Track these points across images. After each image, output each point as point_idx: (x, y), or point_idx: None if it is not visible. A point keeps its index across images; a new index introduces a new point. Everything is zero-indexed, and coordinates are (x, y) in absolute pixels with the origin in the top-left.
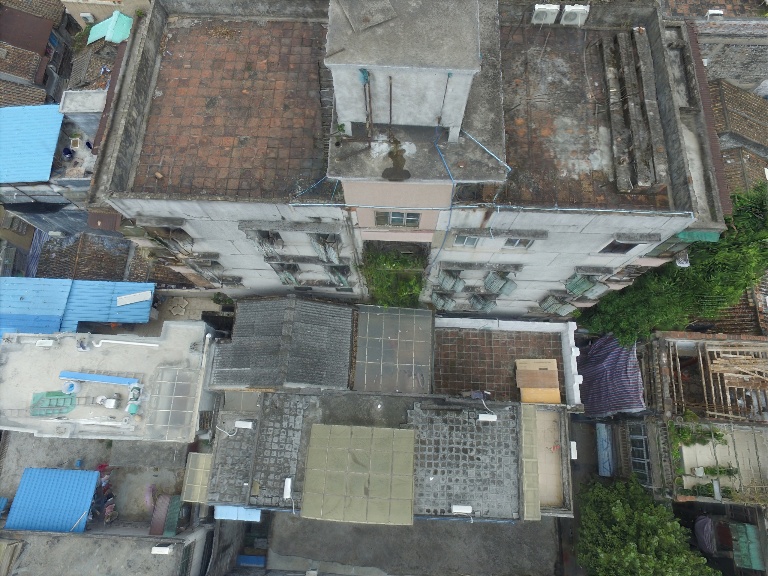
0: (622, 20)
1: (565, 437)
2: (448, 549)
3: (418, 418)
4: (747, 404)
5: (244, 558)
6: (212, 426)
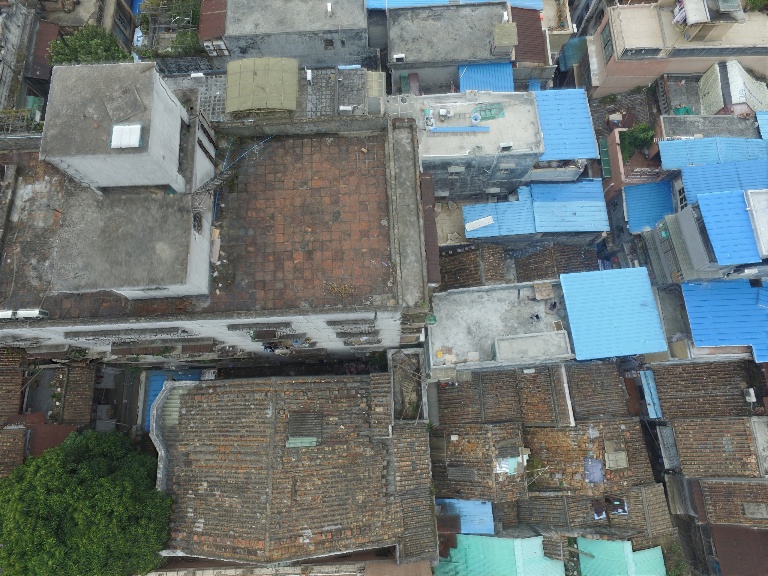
0: None
1: None
2: None
3: None
4: None
5: None
6: None
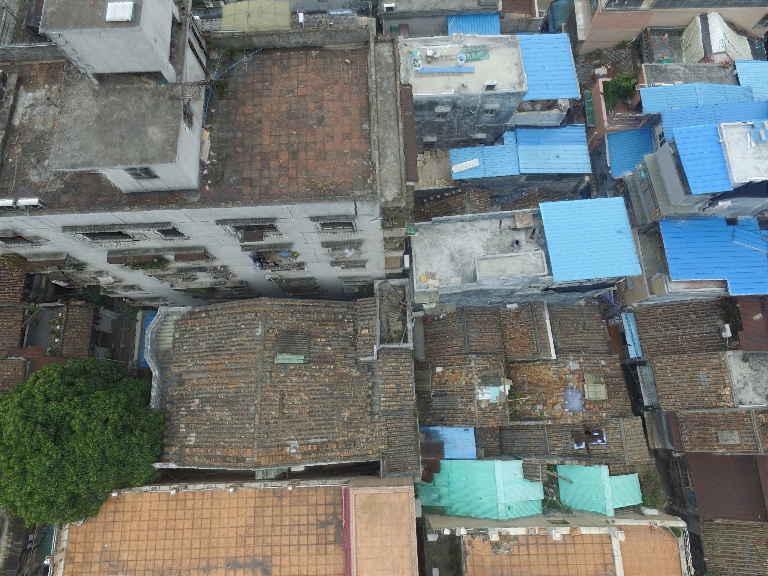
0: None
1: None
2: None
3: None
4: None
5: None
6: None
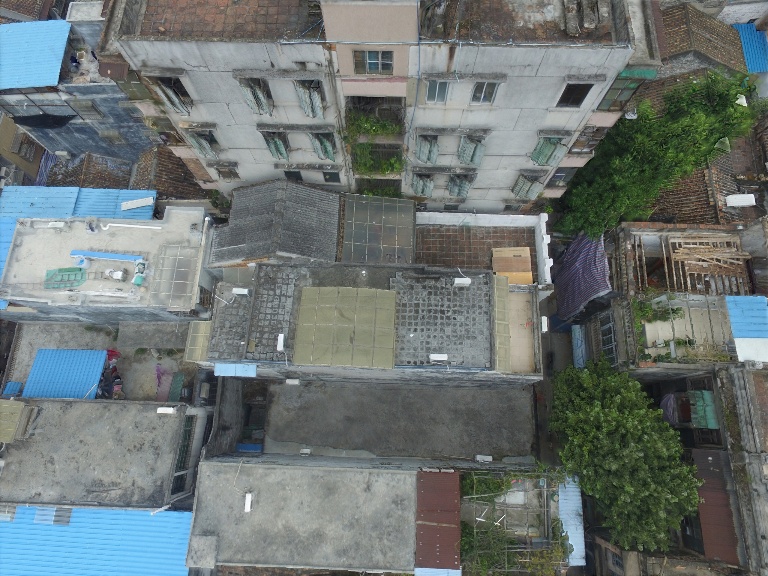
0: None
1: (536, 311)
2: (432, 433)
3: (400, 285)
4: (706, 288)
5: (243, 445)
6: (211, 305)
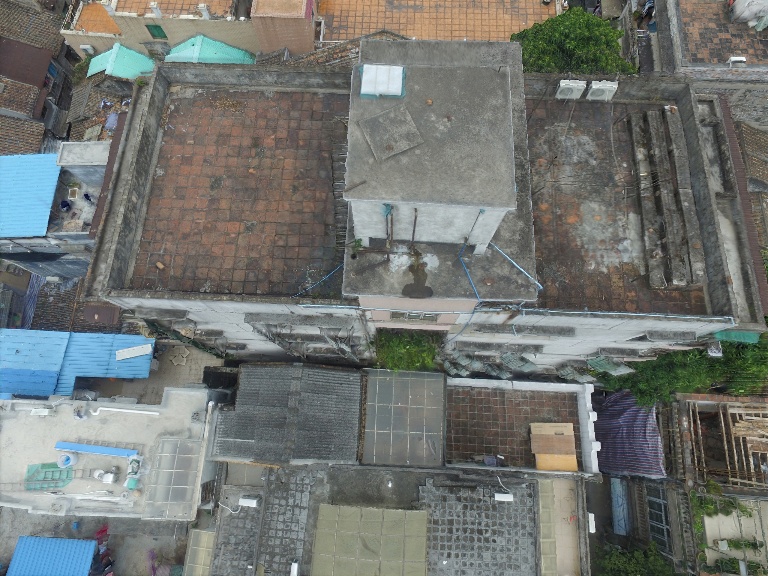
0: (651, 94)
1: (583, 509)
2: None
3: (430, 495)
4: None
5: None
6: (214, 496)
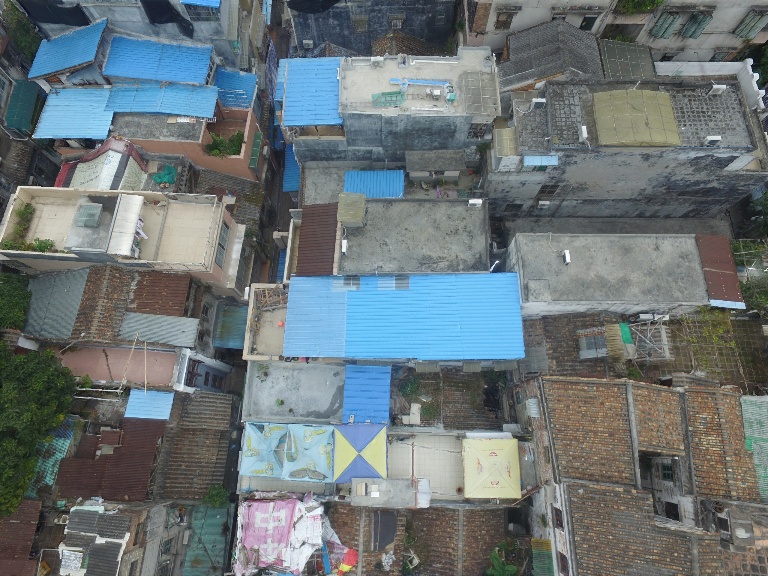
0: None
1: (760, 127)
2: None
3: None
4: None
5: None
6: (494, 128)
